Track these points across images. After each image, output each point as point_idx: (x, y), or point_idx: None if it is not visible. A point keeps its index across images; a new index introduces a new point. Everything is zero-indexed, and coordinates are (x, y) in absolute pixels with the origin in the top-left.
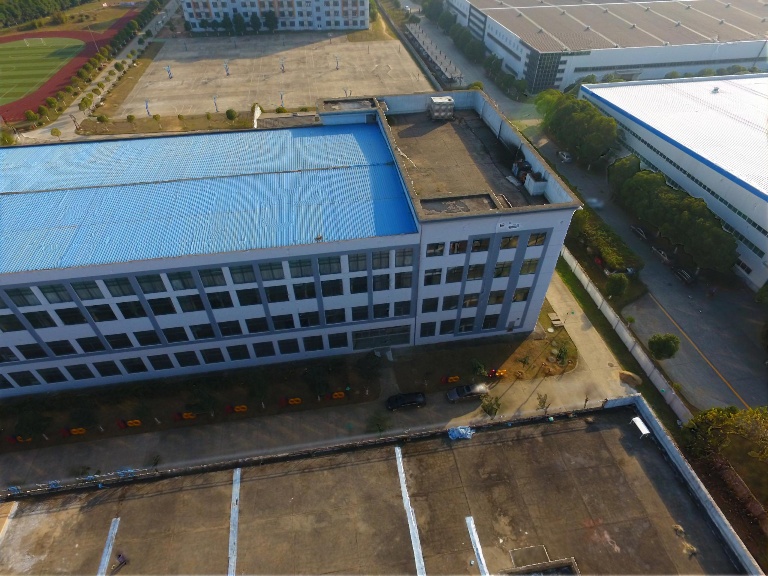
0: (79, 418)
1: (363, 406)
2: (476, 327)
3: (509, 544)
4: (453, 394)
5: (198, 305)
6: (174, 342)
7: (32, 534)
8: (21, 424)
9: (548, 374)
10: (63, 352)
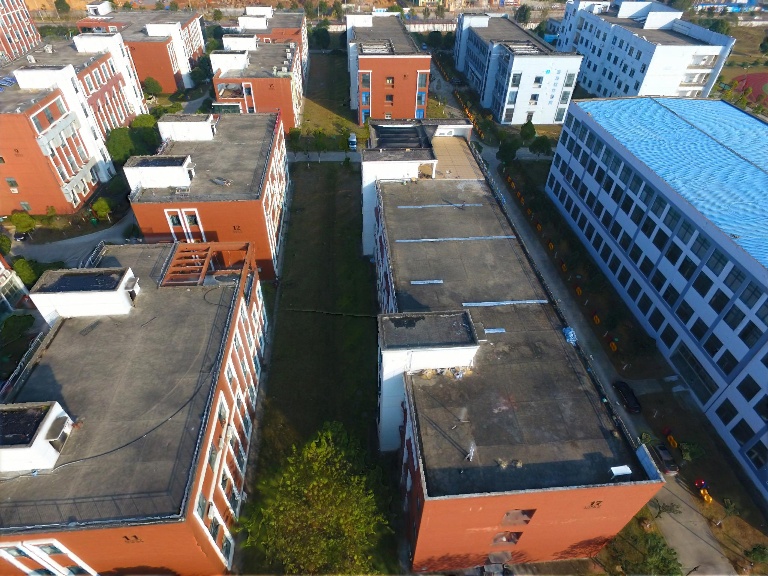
0: (543, 215)
1: (610, 366)
2: (765, 471)
3: (490, 347)
4: (652, 437)
5: (639, 220)
6: (612, 235)
7: (472, 186)
8: (533, 199)
9: (736, 564)
10: (582, 194)
